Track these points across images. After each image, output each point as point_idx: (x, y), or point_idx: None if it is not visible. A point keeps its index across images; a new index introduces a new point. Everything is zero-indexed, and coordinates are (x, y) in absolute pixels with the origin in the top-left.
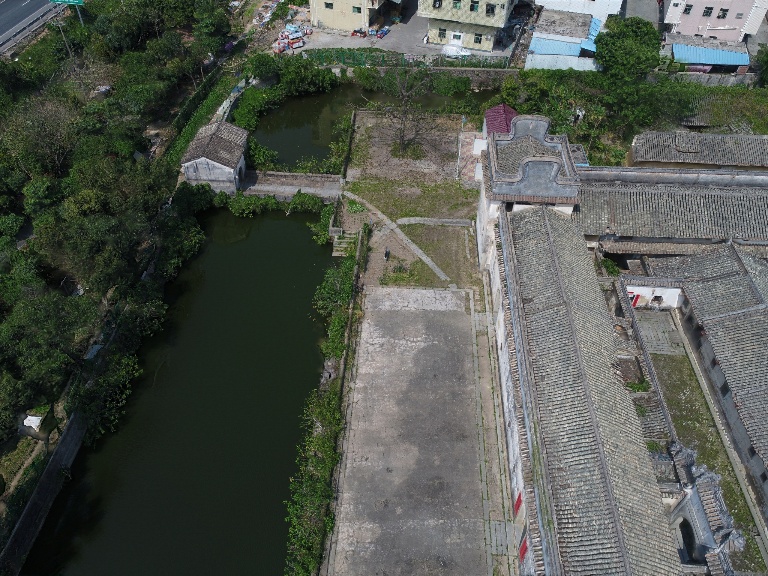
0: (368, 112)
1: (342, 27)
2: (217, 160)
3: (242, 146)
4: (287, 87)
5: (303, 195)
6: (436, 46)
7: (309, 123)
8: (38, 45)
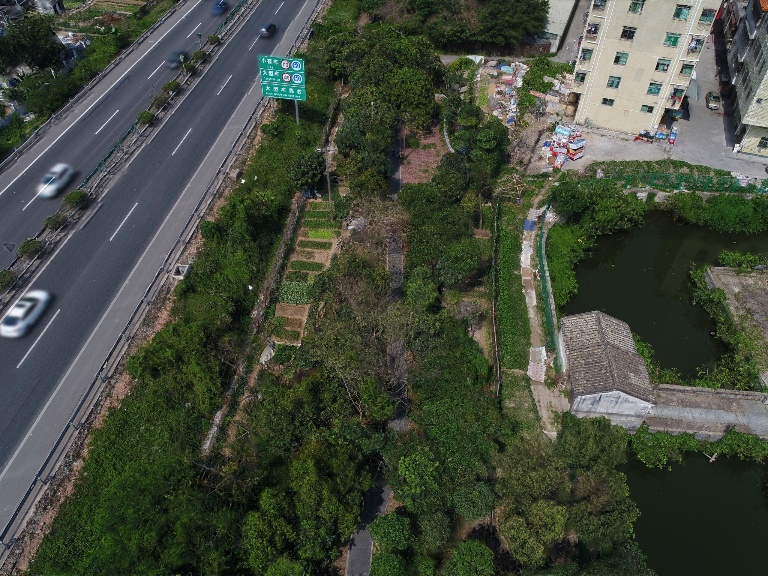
0: (728, 269)
1: (618, 127)
2: (636, 394)
3: (641, 357)
4: (601, 225)
5: (741, 436)
6: (751, 157)
7: (606, 262)
8: (258, 156)
